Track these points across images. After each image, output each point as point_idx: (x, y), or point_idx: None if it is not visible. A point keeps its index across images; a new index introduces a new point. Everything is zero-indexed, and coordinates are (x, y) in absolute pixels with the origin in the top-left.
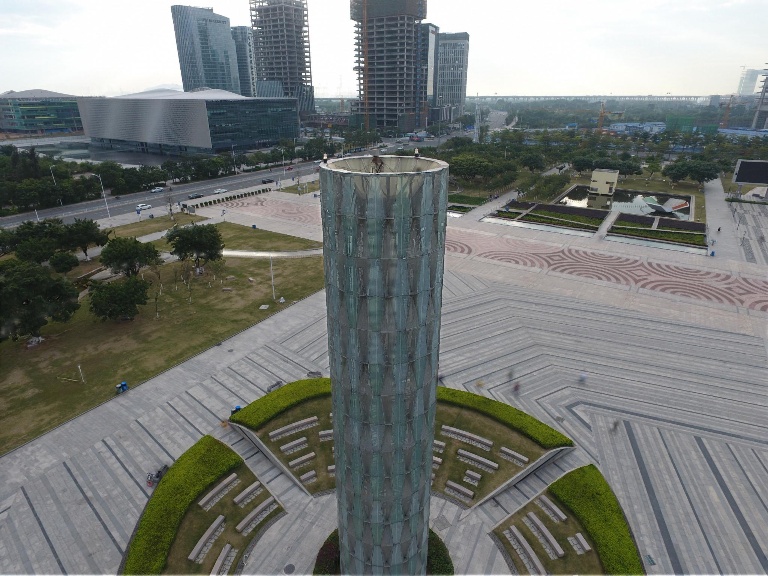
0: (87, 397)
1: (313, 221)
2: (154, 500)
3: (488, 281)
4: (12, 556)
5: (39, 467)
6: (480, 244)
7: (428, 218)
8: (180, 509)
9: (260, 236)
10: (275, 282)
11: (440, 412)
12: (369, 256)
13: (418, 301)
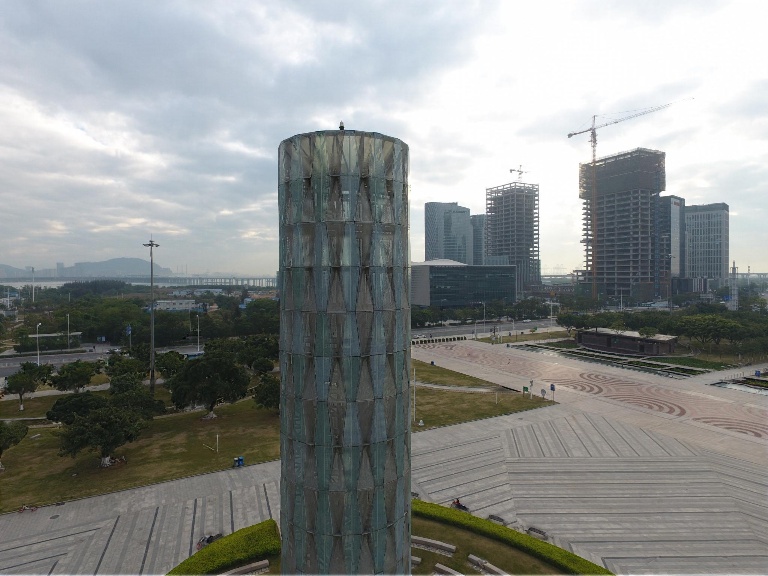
0: (211, 463)
1: (494, 365)
2: (188, 559)
3: (698, 448)
4: (70, 566)
5: (141, 505)
6: (701, 408)
7: (353, 180)
8: (197, 573)
9: (434, 371)
10: (424, 408)
11: (540, 575)
12: (293, 221)
13: (342, 277)
